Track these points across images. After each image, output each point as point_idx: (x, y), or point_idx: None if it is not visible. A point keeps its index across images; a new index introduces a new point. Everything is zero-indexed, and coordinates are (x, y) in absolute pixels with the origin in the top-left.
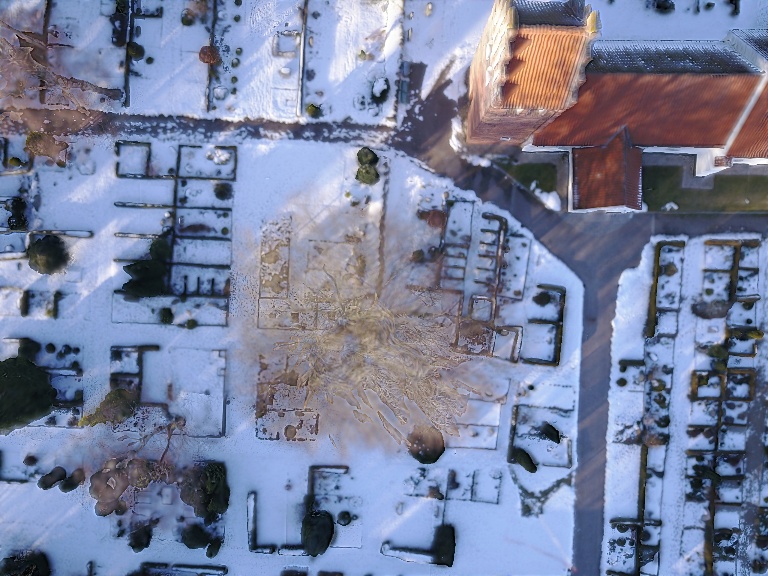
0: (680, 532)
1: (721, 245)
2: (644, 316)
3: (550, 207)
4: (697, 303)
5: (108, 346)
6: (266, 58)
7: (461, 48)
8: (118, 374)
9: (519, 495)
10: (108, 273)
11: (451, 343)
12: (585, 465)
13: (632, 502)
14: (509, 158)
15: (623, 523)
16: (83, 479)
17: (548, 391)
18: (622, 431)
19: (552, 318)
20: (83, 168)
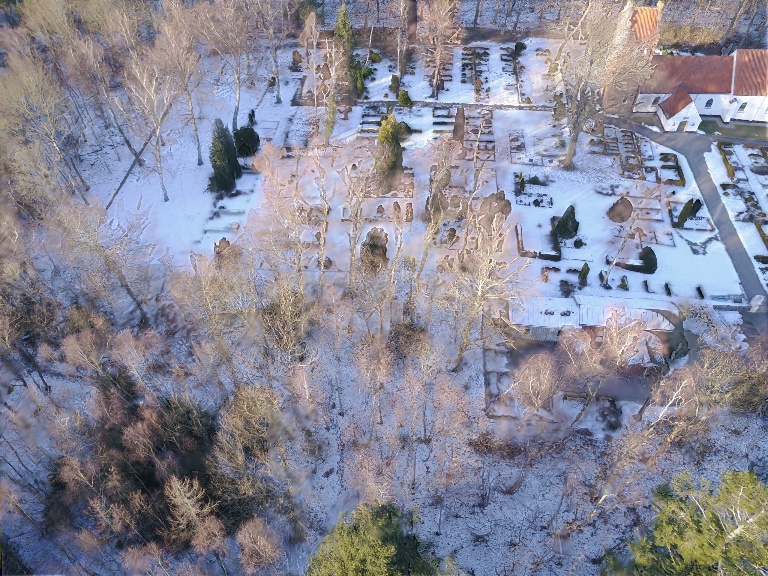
0: None
1: (752, 148)
2: None
3: (655, 130)
4: (752, 168)
5: (429, 167)
6: (501, 91)
7: None
8: None
9: (687, 244)
10: None
11: (620, 174)
12: (723, 231)
13: (764, 250)
14: (627, 115)
15: (763, 255)
16: (412, 219)
17: None
18: (738, 215)
19: None
20: (417, 114)
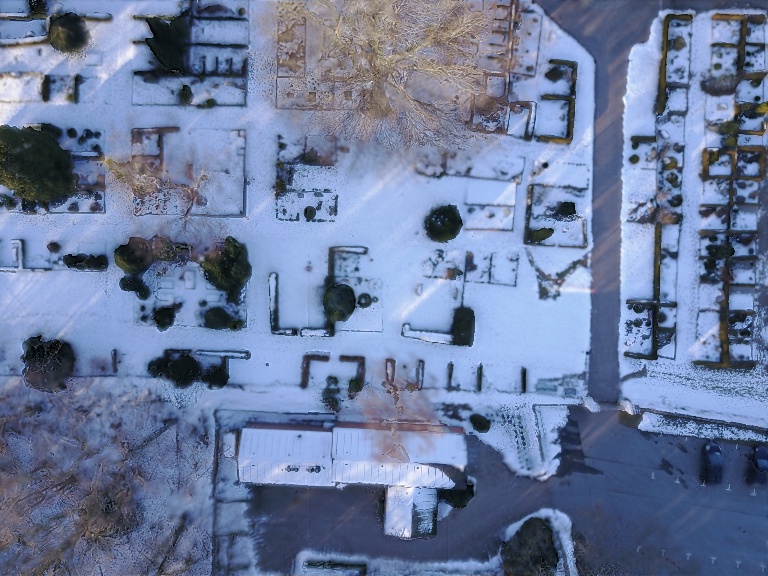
0: (695, 315)
1: (728, 20)
2: (654, 92)
3: None
4: (706, 80)
5: (129, 129)
6: None
7: None
8: (139, 156)
9: (536, 278)
10: (128, 56)
11: (466, 121)
12: (600, 245)
13: (648, 282)
14: None
15: (639, 301)
16: (106, 265)
17: (562, 170)
18: (636, 209)
19: (565, 93)
20: None
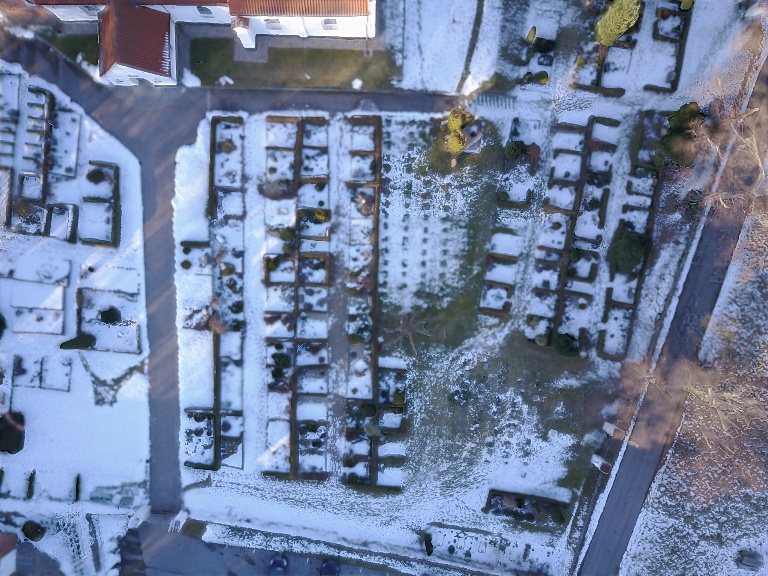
0: (265, 424)
1: (283, 122)
2: (205, 196)
3: (98, 80)
4: (263, 183)
5: None
6: None
7: None
8: None
9: (92, 383)
10: None
11: (5, 222)
12: (157, 352)
13: (209, 391)
14: (52, 29)
15: (195, 411)
16: None
17: (112, 274)
18: (191, 316)
19: (106, 196)
20: None
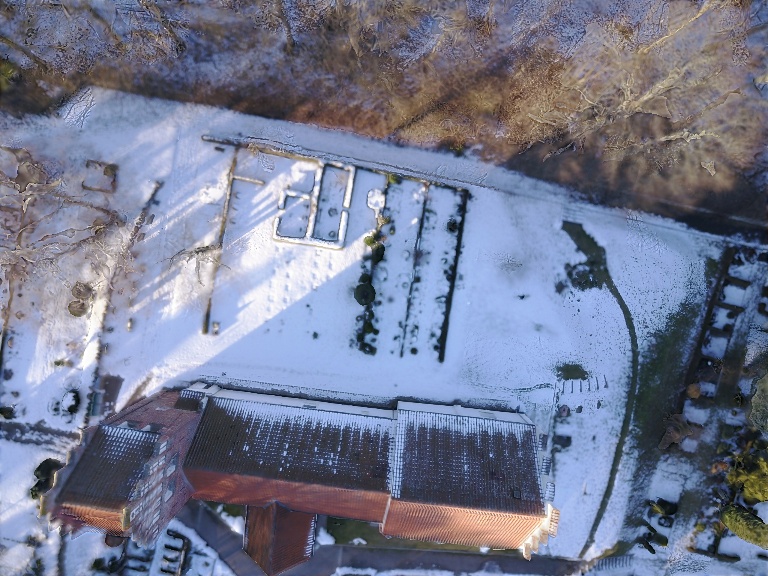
0: None
1: None
2: None
3: (236, 531)
4: None
5: None
6: None
7: (158, 367)
8: None
9: None
10: None
11: None
12: None
13: None
14: None
15: None
16: None
17: None
18: None
19: None
20: None
